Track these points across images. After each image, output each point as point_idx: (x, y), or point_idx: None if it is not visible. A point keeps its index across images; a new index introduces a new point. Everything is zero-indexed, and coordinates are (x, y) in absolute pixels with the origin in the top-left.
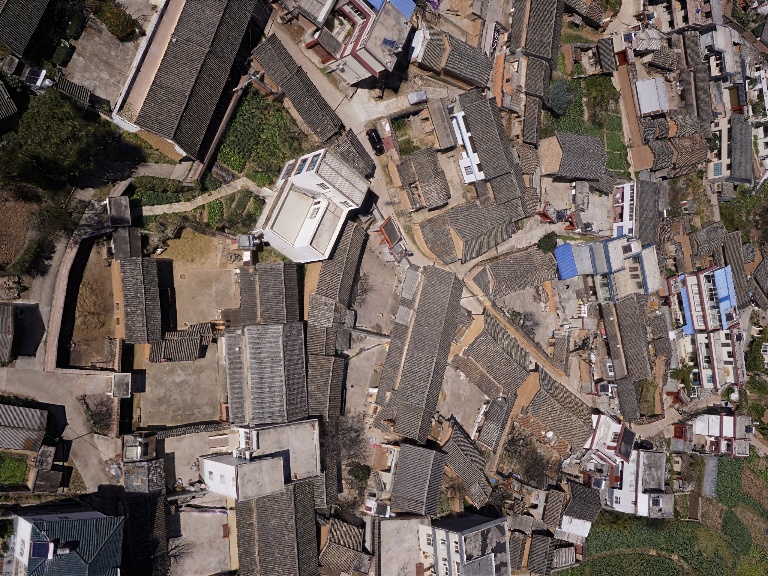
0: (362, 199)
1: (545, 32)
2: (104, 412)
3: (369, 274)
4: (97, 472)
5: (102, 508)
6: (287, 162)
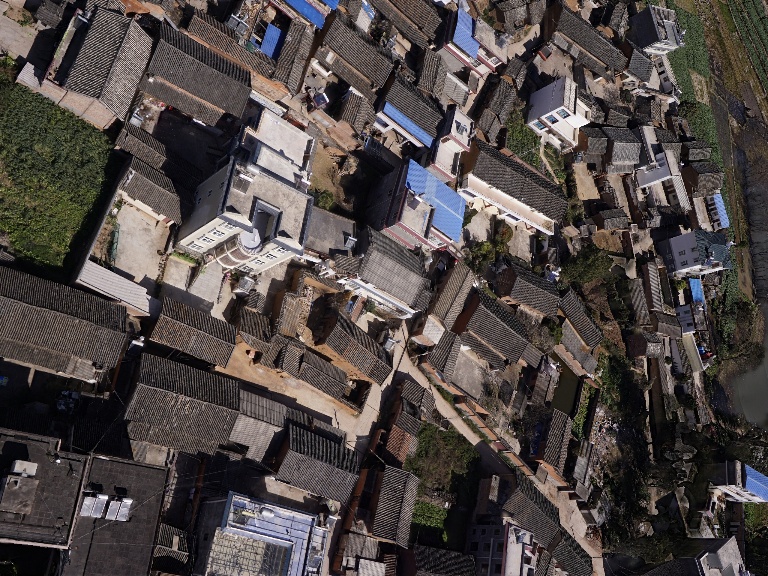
0: (574, 83)
1: None
2: None
3: (551, 70)
4: (647, 239)
5: (655, 236)
6: (528, 124)
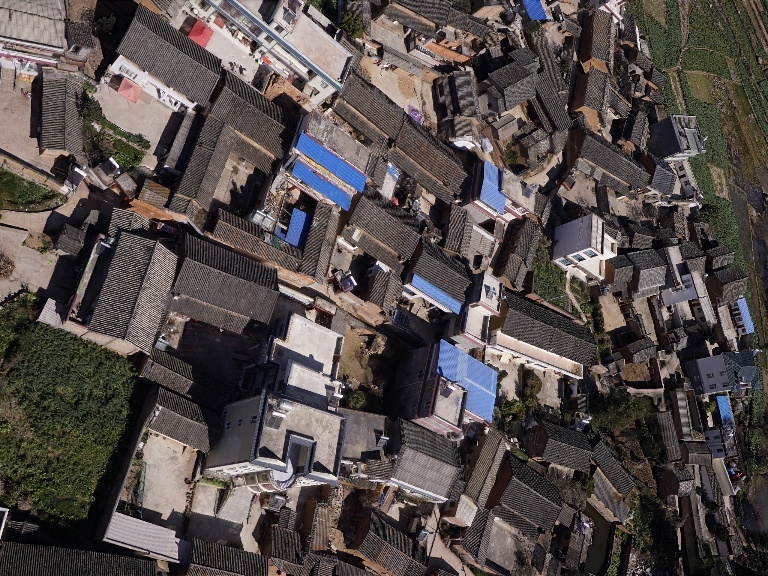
0: (601, 219)
1: (431, 1)
2: (660, 360)
3: (574, 195)
4: (674, 360)
5: (682, 355)
6: None
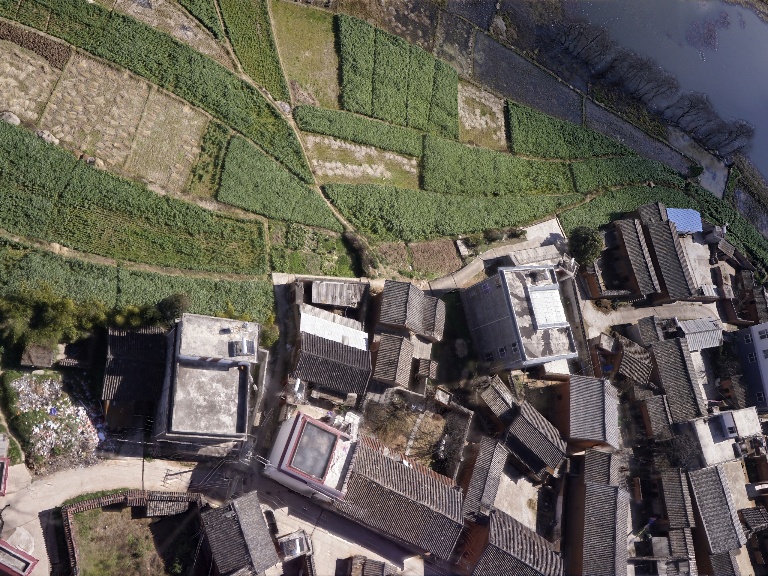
0: None
1: None
2: None
3: None
4: None
5: None
6: None
